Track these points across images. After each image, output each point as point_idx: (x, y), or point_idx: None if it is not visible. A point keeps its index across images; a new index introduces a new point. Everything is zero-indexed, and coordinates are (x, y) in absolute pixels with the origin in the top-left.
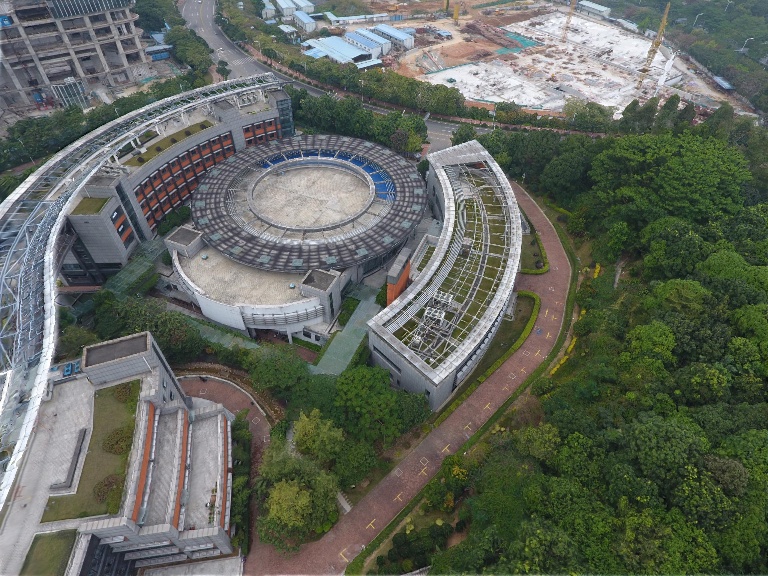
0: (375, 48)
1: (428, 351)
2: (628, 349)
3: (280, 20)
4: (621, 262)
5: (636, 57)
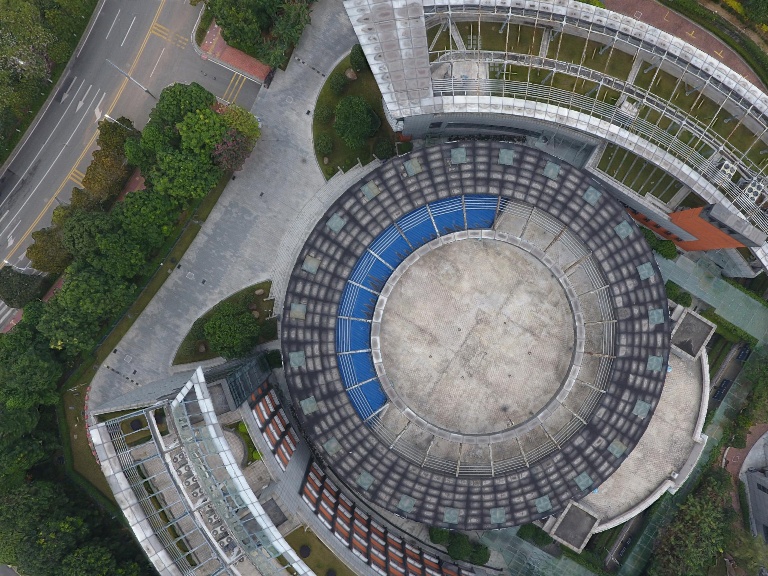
0: None
1: None
2: None
3: None
4: None
5: None
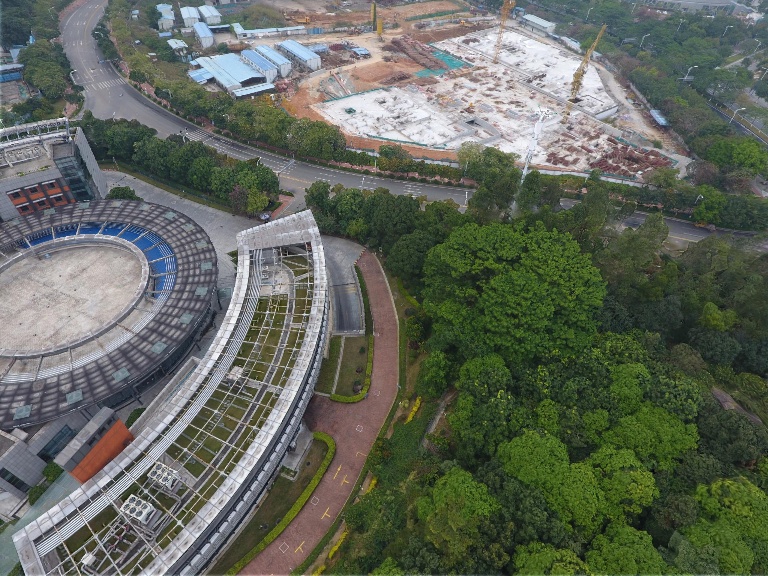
0: (269, 70)
1: (110, 571)
2: None
3: (179, 32)
4: (448, 396)
5: (570, 83)
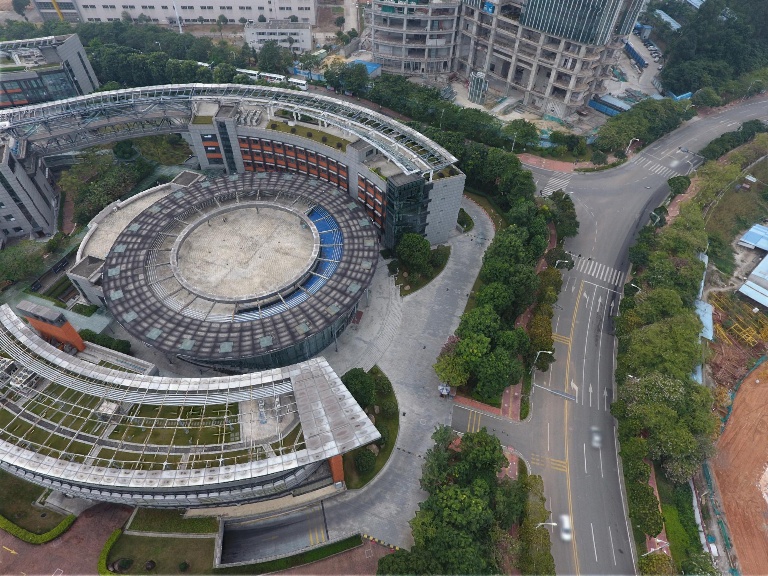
0: None
1: None
2: None
3: None
4: None
5: None
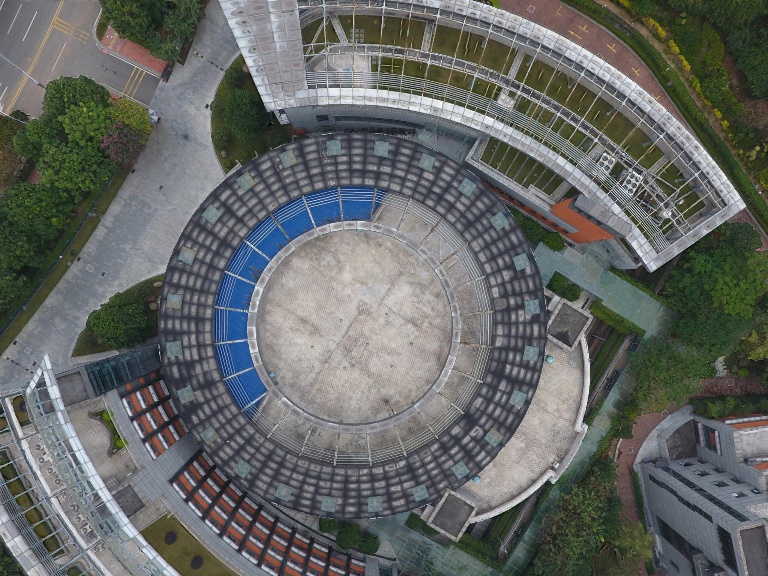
0: None
1: None
2: None
3: None
4: None
5: None
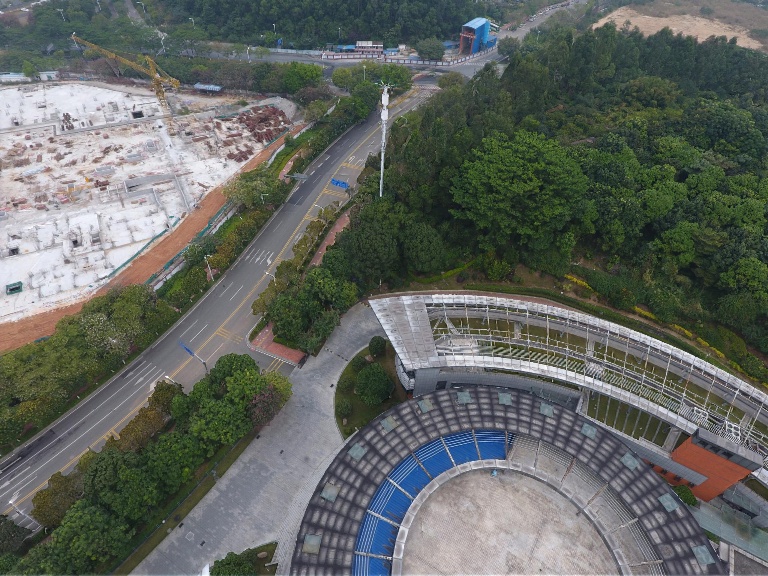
0: None
1: None
2: (752, 290)
3: None
4: None
5: (101, 106)
